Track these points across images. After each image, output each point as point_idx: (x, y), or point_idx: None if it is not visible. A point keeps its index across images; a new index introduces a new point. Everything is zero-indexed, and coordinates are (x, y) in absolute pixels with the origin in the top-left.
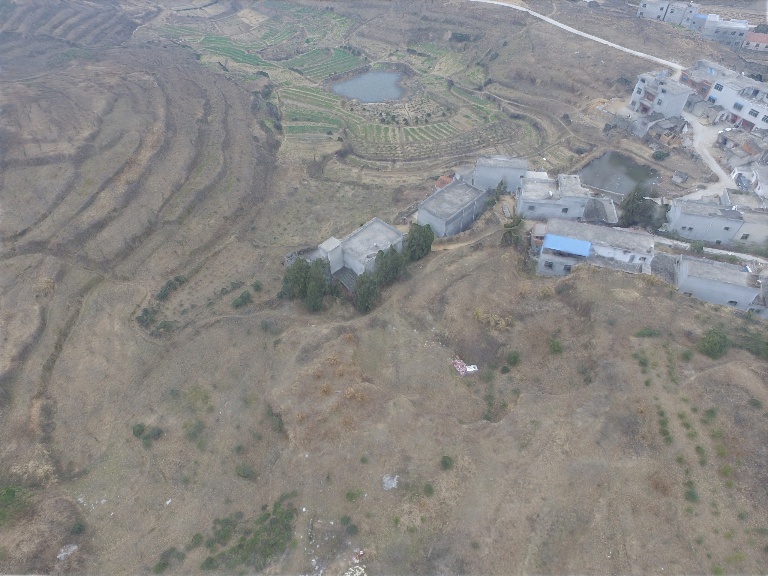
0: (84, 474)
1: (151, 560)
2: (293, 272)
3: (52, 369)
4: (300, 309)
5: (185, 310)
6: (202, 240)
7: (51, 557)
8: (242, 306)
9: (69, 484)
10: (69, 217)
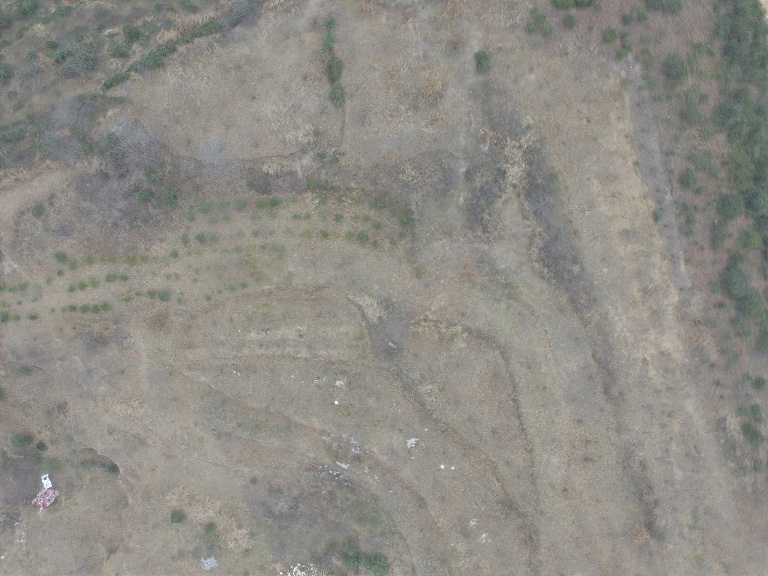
0: None
1: None
2: None
3: None
4: None
5: None
6: None
7: None
8: None
9: None
10: None
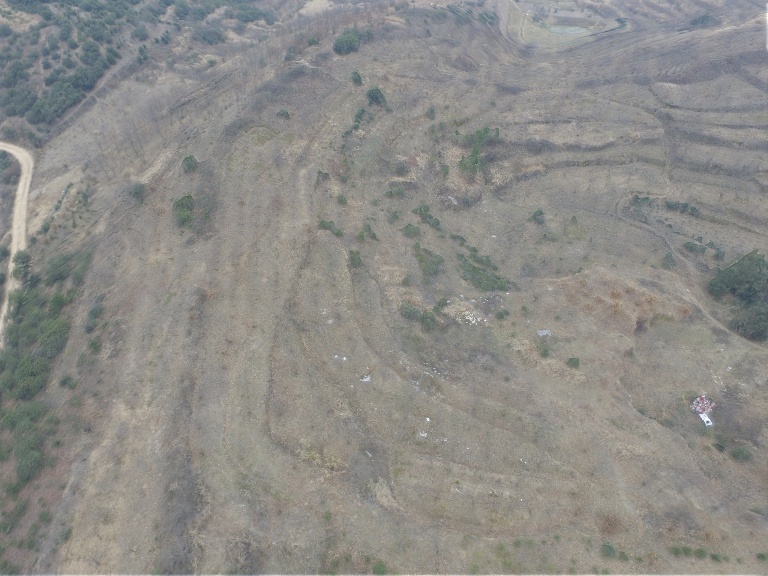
0: (500, 200)
1: (456, 234)
2: (743, 257)
3: (567, 167)
4: (705, 282)
5: (661, 221)
6: (752, 211)
7: (448, 194)
8: (686, 249)
9: (492, 195)
10: (710, 122)
